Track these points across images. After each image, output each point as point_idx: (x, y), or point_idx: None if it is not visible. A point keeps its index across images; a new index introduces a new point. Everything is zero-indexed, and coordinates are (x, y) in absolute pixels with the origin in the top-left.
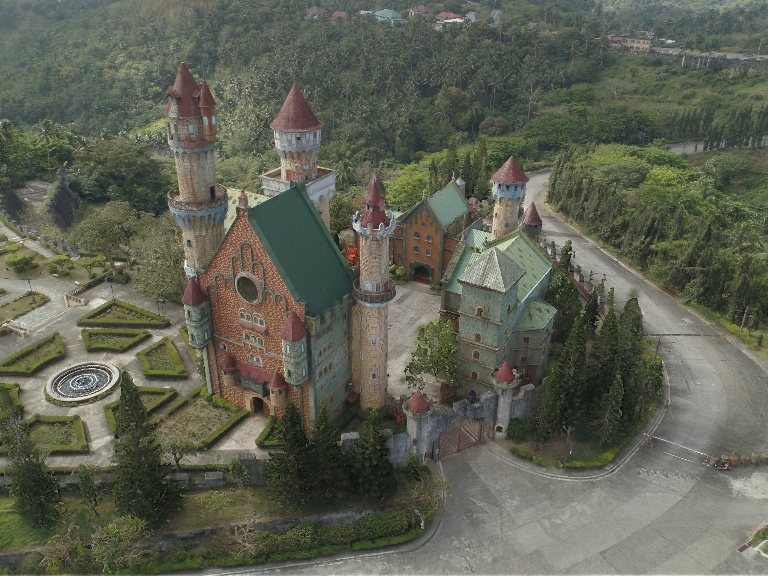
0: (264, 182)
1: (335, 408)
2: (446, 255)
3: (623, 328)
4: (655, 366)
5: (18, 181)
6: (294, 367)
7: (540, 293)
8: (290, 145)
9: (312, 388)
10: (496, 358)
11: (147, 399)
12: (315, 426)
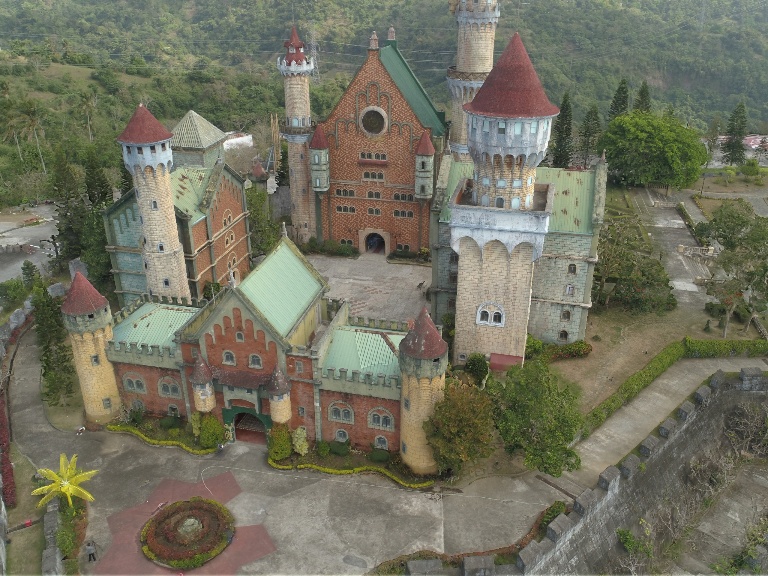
0: None
1: None
2: None
3: None
4: None
5: None
6: None
7: None
8: None
9: None
10: None
11: None
12: None
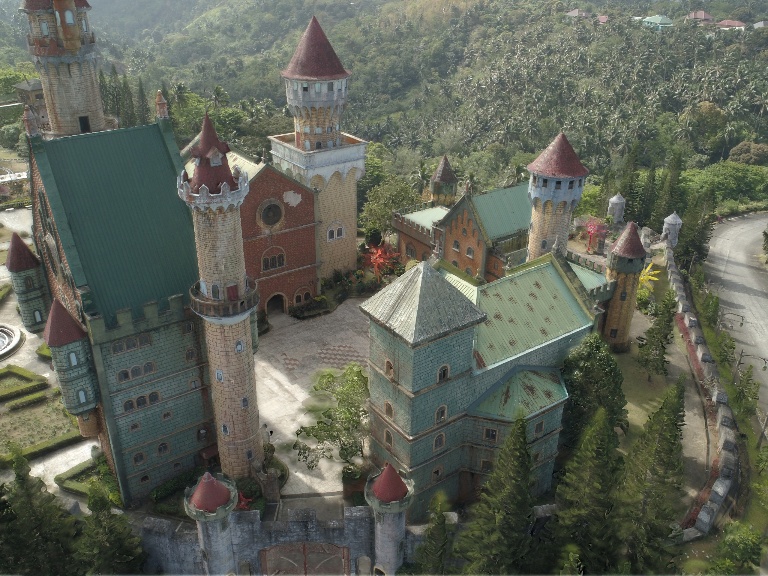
0: (273, 145)
1: (173, 460)
2: (490, 280)
3: (637, 461)
4: (742, 544)
5: (178, 143)
6: (61, 385)
7: (559, 362)
8: (296, 97)
9: (107, 423)
10: (411, 451)
11: (10, 383)
12: (6, 486)
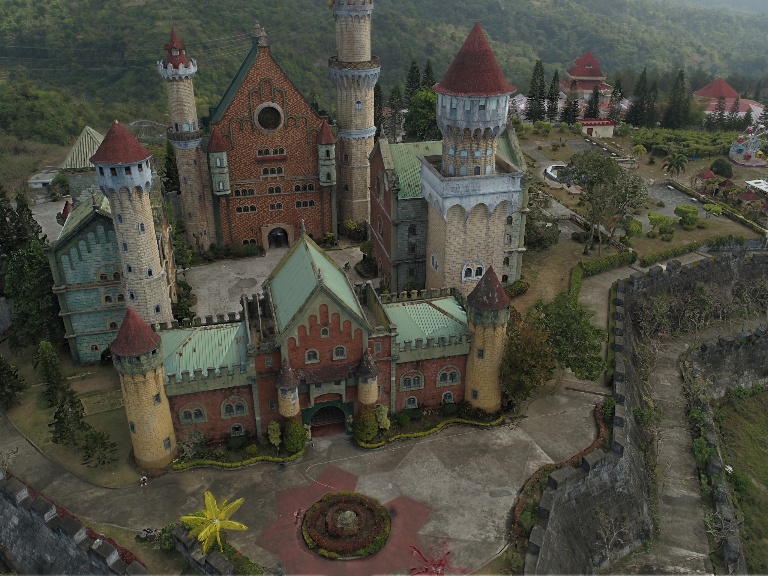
0: None
1: None
2: None
3: None
4: None
5: None
6: None
7: None
8: None
9: None
10: None
11: None
12: None
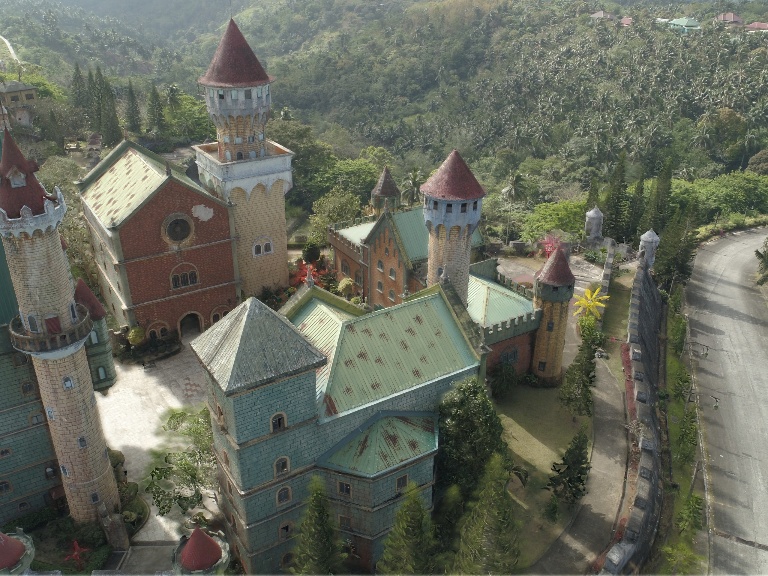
0: (197, 155)
1: (18, 500)
2: None
3: (467, 539)
4: None
5: (168, 146)
6: None
7: None
8: (213, 105)
9: None
10: (247, 507)
11: None
12: None
